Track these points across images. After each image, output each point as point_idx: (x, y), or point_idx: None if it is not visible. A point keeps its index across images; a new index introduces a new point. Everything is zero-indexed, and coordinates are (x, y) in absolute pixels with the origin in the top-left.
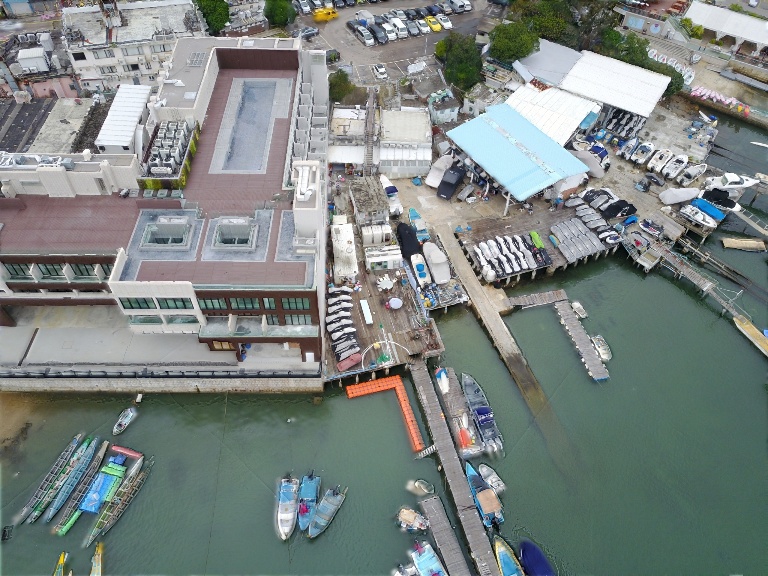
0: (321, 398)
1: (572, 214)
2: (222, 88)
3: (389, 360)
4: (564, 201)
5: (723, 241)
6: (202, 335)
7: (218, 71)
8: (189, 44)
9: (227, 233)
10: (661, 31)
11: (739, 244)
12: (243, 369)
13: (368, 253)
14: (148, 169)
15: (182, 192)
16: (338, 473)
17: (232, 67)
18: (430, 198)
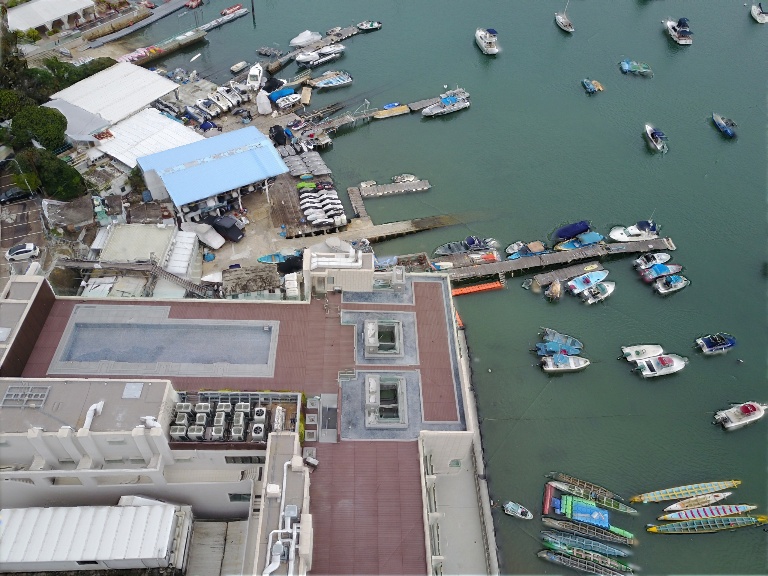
0: None
1: None
2: None
3: None
4: None
5: None
6: None
7: None
8: None
9: None
10: None
11: (305, 97)
12: None
13: None
14: None
15: (311, 398)
16: (527, 336)
17: None
18: (236, 250)
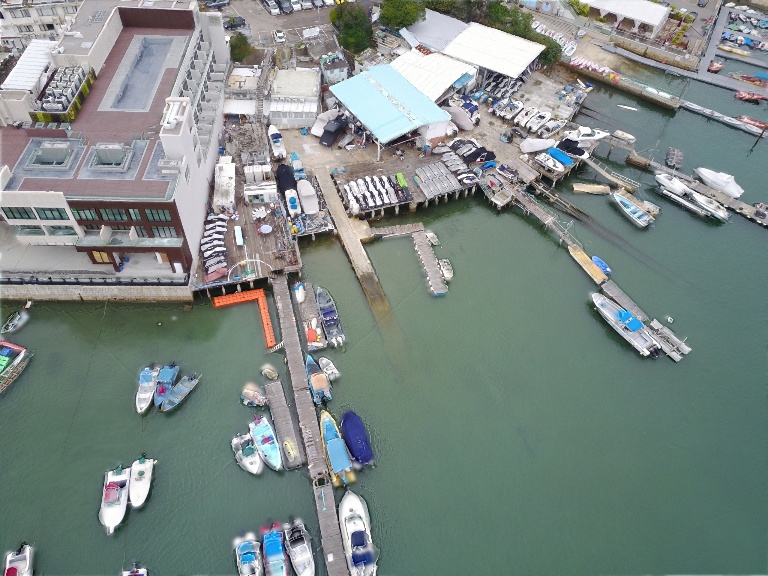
0: (191, 306)
1: (439, 160)
2: (123, 43)
3: (251, 273)
4: (432, 149)
5: (573, 185)
6: (79, 244)
7: (122, 29)
8: (94, 4)
9: (104, 158)
10: (552, 9)
11: (587, 188)
12: (119, 278)
13: (246, 188)
14: (42, 106)
15: (70, 125)
16: (197, 365)
17: (135, 26)
18: (314, 146)
